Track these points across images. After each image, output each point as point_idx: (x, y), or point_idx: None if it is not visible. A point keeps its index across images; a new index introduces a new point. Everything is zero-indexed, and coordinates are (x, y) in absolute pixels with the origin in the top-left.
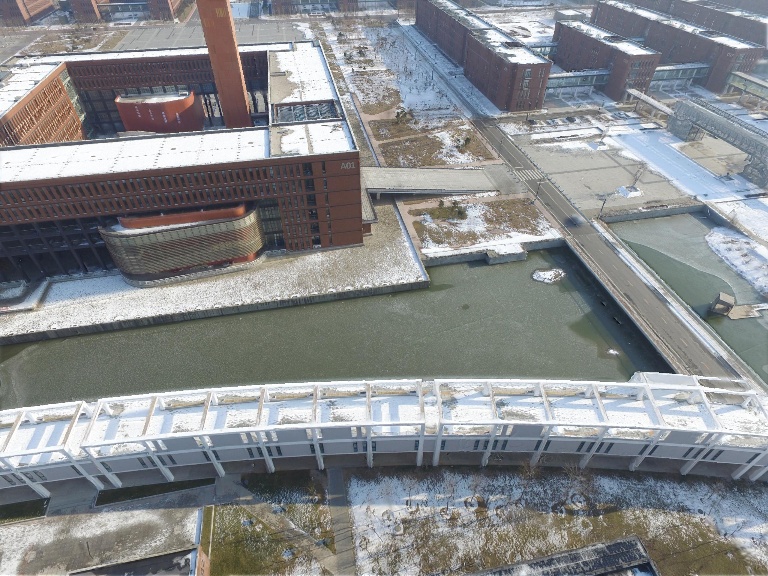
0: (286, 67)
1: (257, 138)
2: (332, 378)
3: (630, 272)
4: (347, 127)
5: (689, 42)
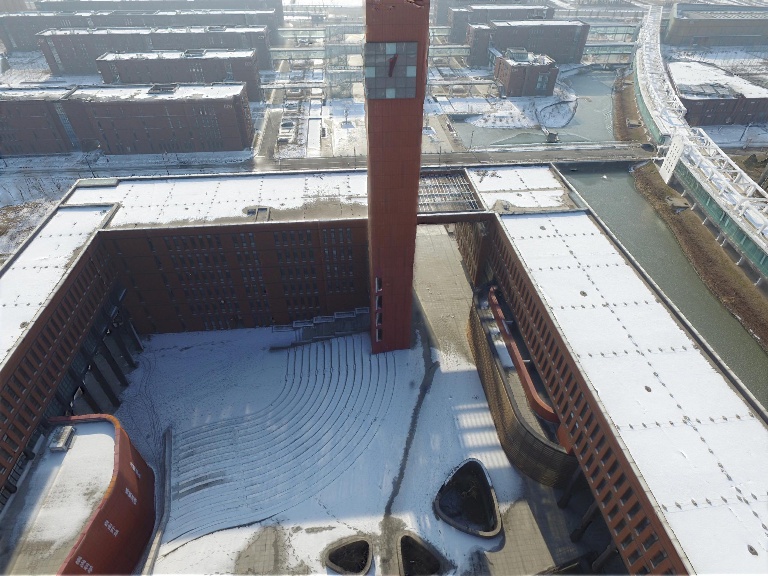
0: (220, 211)
1: (528, 223)
2: (698, 288)
3: (532, 152)
4: (485, 168)
5: (212, 40)
